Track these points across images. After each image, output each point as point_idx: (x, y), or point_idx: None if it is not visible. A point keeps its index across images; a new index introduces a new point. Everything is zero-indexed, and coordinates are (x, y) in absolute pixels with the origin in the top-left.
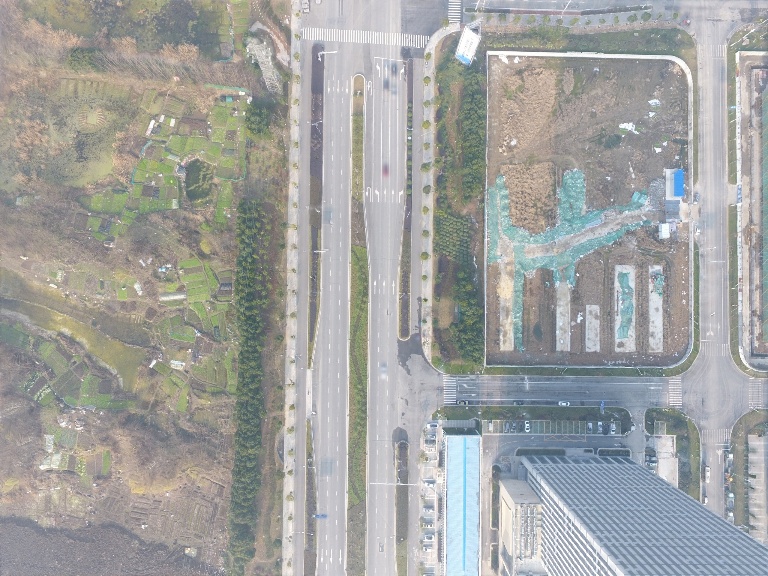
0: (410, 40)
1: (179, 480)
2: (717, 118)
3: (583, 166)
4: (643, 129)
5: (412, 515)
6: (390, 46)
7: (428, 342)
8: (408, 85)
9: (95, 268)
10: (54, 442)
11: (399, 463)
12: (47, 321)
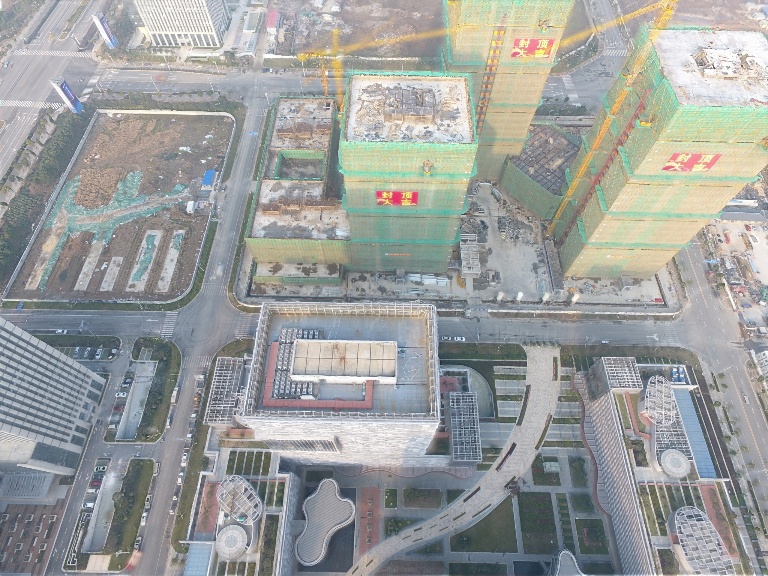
0: (49, 105)
1: None
2: (252, 145)
3: (144, 170)
4: (196, 150)
5: None
6: (34, 108)
7: None
8: (34, 126)
9: None
10: None
11: None
12: None
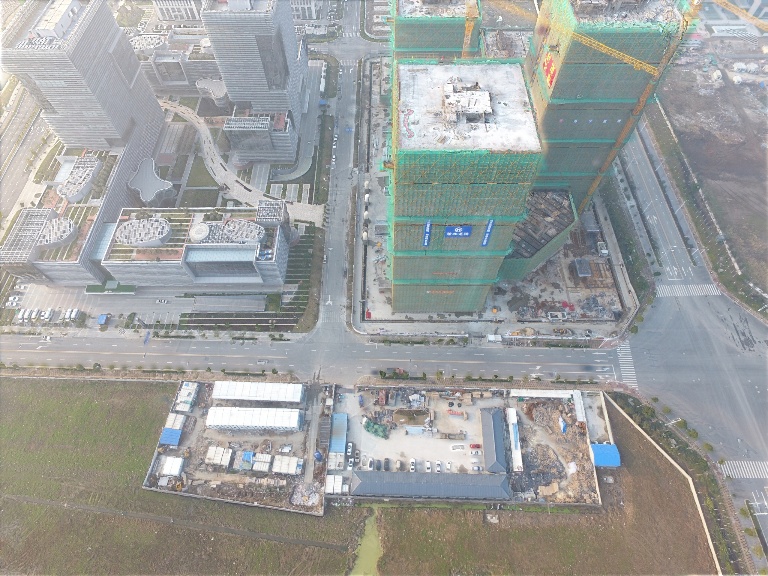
0: None
1: None
2: None
3: None
4: None
5: None
6: None
7: None
8: None
9: None
10: None
11: None
12: None
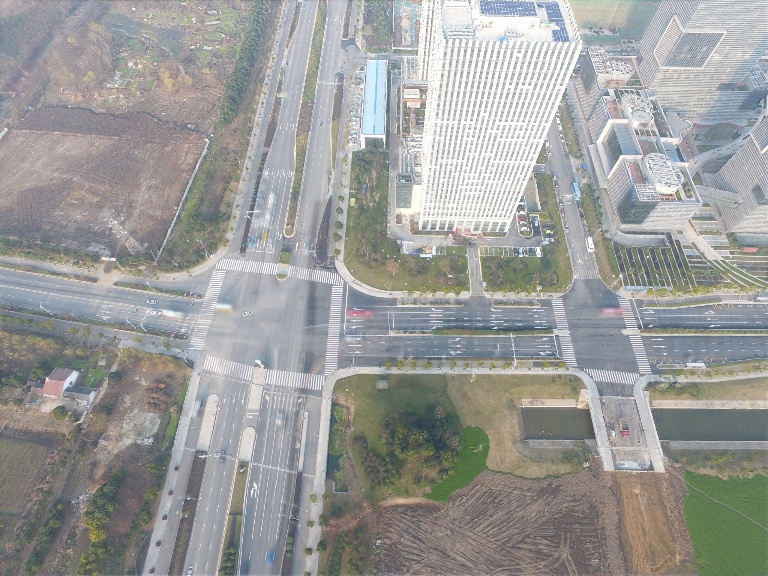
0: None
1: (194, 93)
2: None
3: None
4: None
5: (344, 110)
6: None
7: (359, 41)
8: None
9: (172, 12)
10: (121, 75)
11: (337, 85)
12: (136, 32)
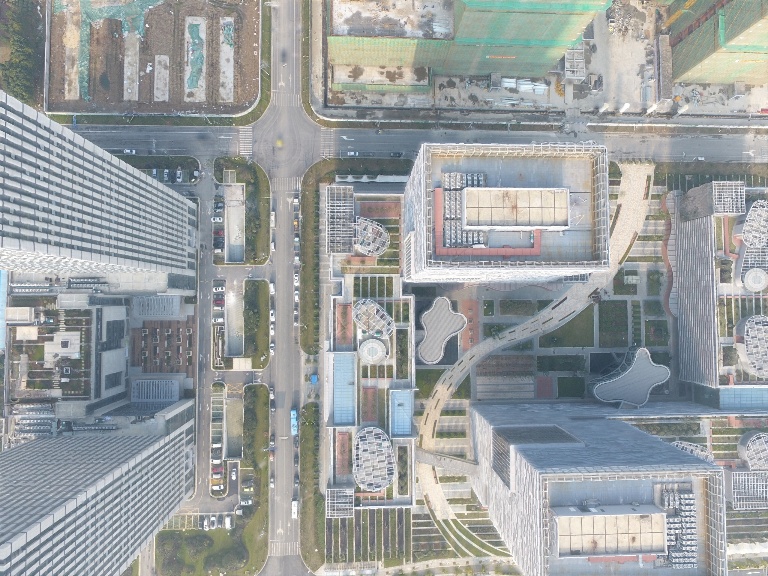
0: None
1: None
2: None
3: None
4: None
5: None
6: None
7: None
8: None
9: None
10: None
11: None
12: None
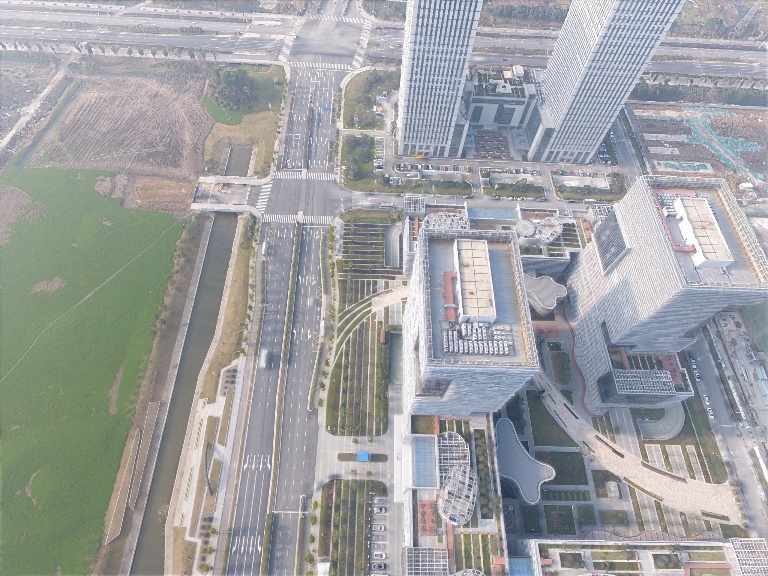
0: None
1: (524, 1)
2: None
3: (764, 151)
4: None
5: None
6: None
7: None
8: None
9: None
10: None
11: None
12: None
